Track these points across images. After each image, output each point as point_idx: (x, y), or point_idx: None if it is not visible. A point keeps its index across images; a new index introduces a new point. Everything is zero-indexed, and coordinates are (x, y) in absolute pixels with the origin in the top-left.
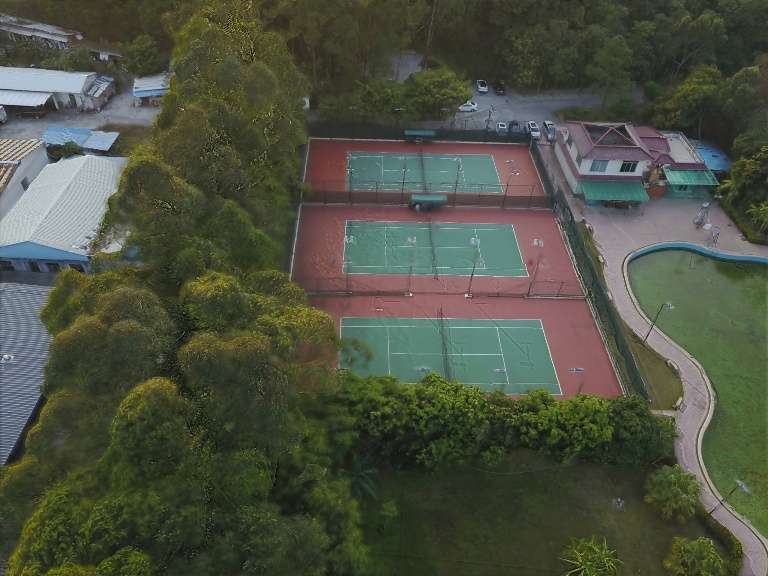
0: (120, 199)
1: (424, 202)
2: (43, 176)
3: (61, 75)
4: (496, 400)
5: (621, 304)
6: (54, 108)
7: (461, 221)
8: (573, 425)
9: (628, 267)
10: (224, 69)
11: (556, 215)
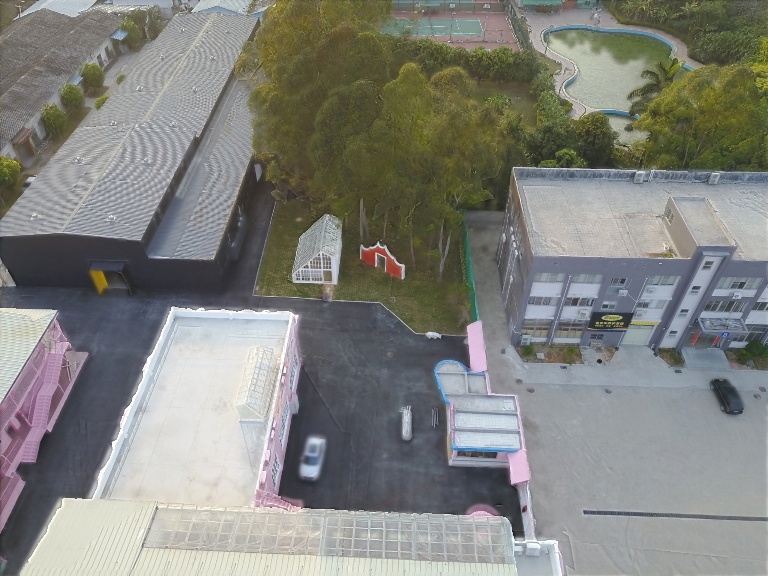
0: None
1: (426, 8)
2: None
3: None
4: (457, 49)
5: (536, 45)
6: None
7: (448, 17)
8: (494, 57)
9: (545, 36)
10: None
11: (506, 14)
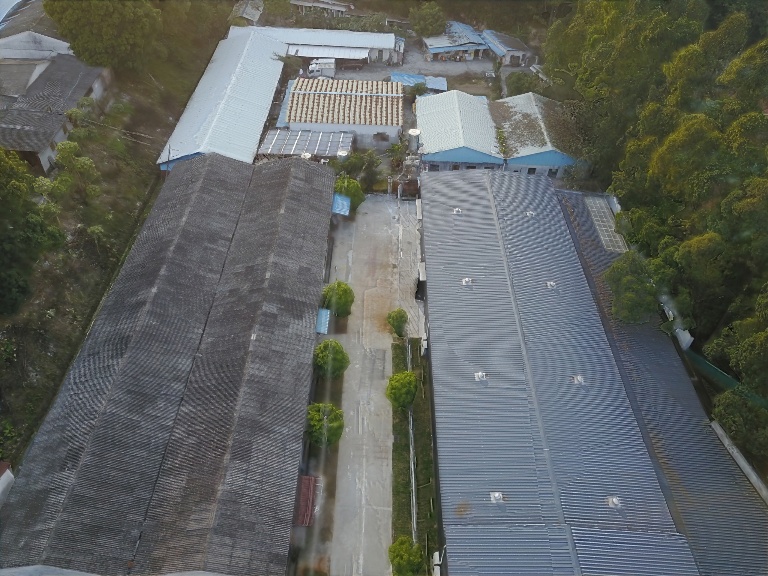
0: (763, 64)
1: None
2: (423, 106)
3: (373, 34)
4: None
5: None
6: (366, 62)
7: None
8: None
9: None
10: (679, 2)
11: None
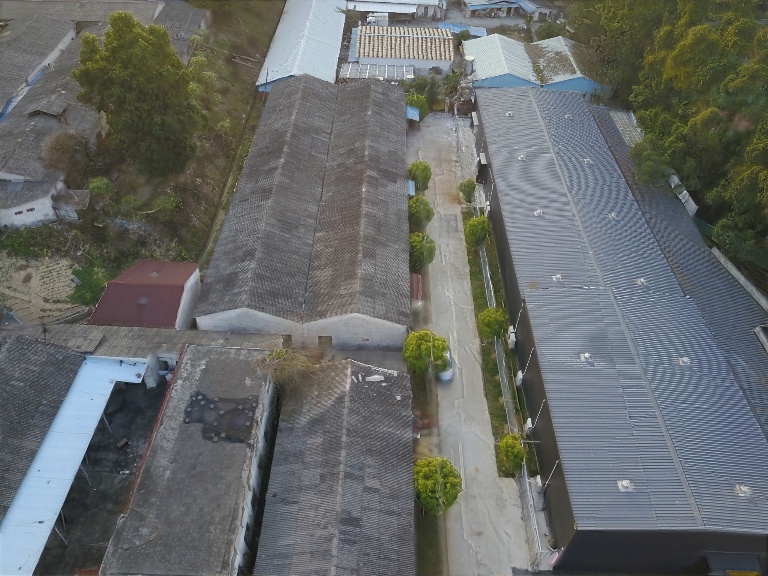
0: None
1: None
2: (470, 47)
3: None
4: None
5: None
6: (414, 17)
7: None
8: None
9: None
10: None
11: None
